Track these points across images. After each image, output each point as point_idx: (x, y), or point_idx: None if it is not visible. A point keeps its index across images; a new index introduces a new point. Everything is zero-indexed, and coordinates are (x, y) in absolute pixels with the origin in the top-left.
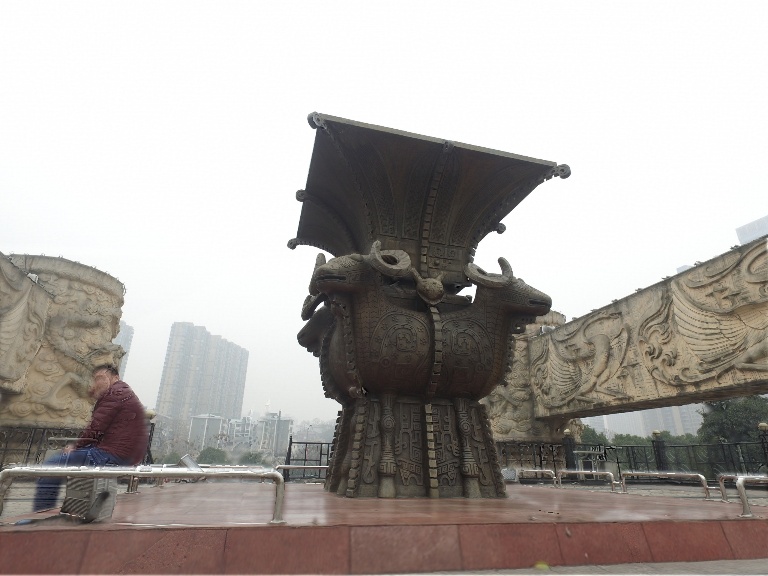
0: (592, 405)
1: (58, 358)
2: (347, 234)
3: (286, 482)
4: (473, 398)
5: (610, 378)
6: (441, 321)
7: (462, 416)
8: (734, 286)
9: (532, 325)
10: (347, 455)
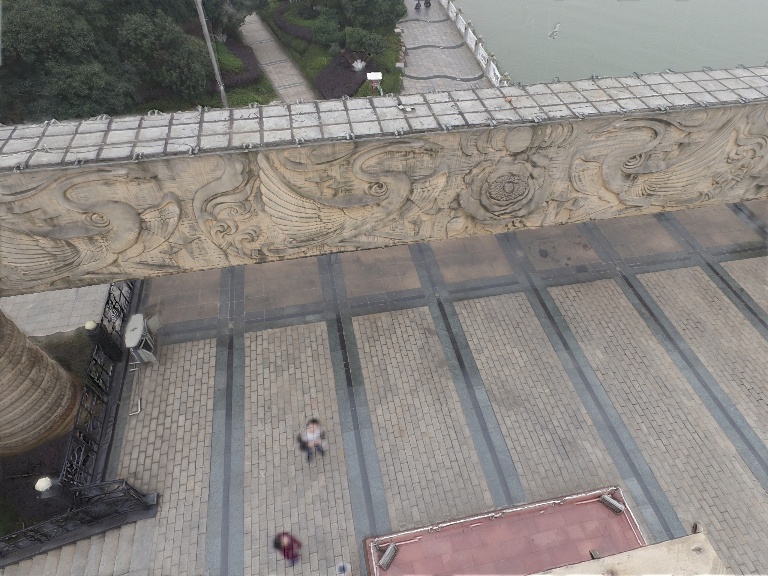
0: None
1: None
2: None
3: None
4: None
5: (145, 252)
6: None
7: None
8: (341, 177)
9: None
10: None
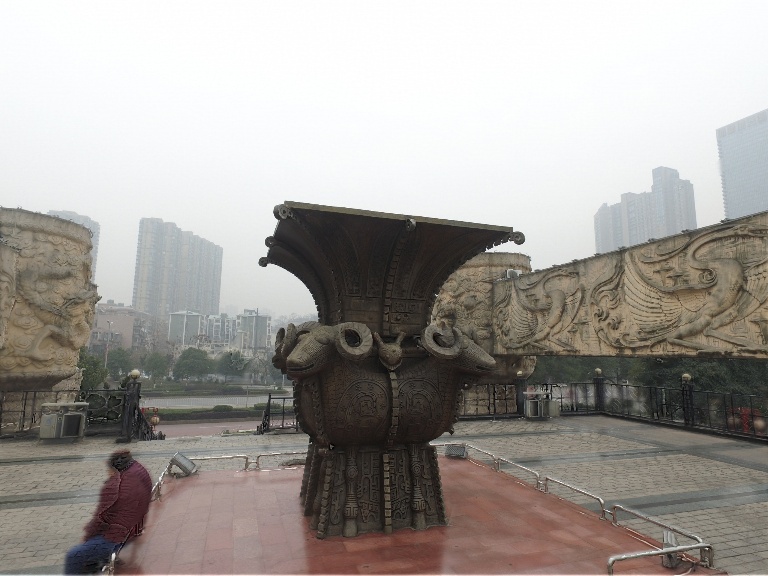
0: (544, 352)
1: (34, 312)
2: (316, 280)
3: (267, 433)
4: (424, 442)
5: (562, 331)
6: (399, 384)
7: (414, 460)
8: (679, 267)
9: (498, 268)
10: (318, 495)
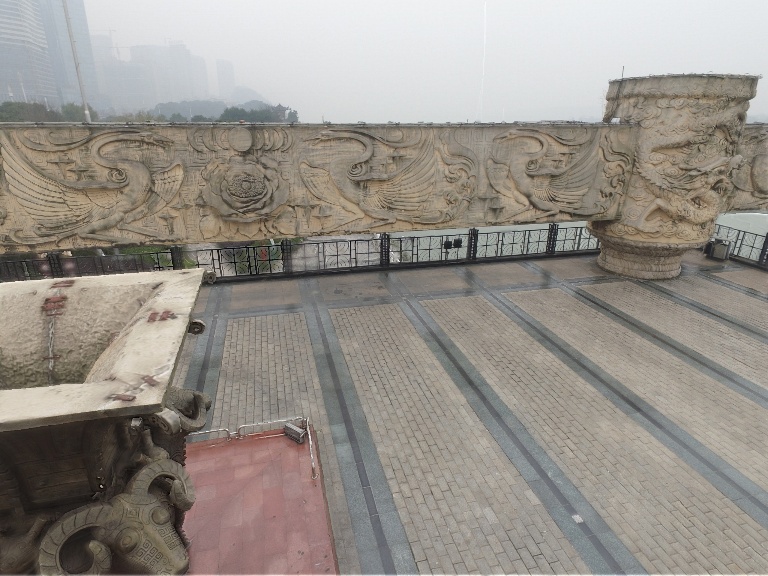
0: None
1: None
2: None
3: None
4: None
5: None
6: None
7: None
8: (81, 162)
9: None
10: None
